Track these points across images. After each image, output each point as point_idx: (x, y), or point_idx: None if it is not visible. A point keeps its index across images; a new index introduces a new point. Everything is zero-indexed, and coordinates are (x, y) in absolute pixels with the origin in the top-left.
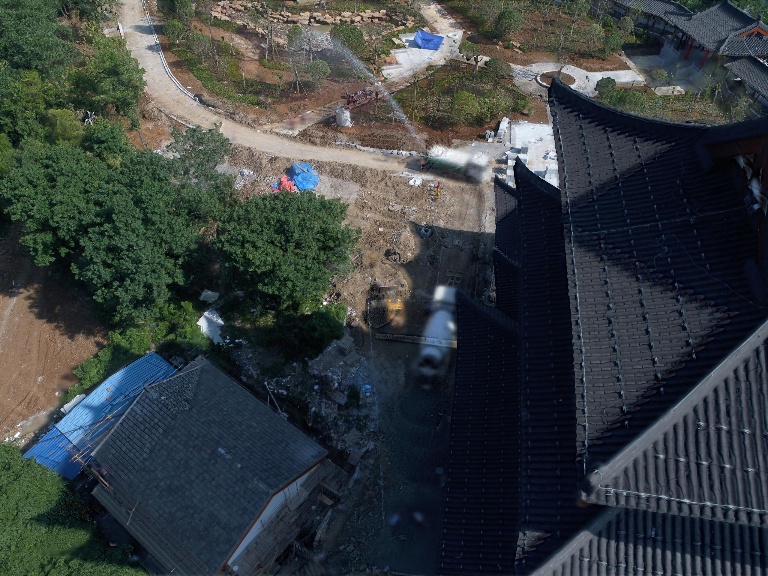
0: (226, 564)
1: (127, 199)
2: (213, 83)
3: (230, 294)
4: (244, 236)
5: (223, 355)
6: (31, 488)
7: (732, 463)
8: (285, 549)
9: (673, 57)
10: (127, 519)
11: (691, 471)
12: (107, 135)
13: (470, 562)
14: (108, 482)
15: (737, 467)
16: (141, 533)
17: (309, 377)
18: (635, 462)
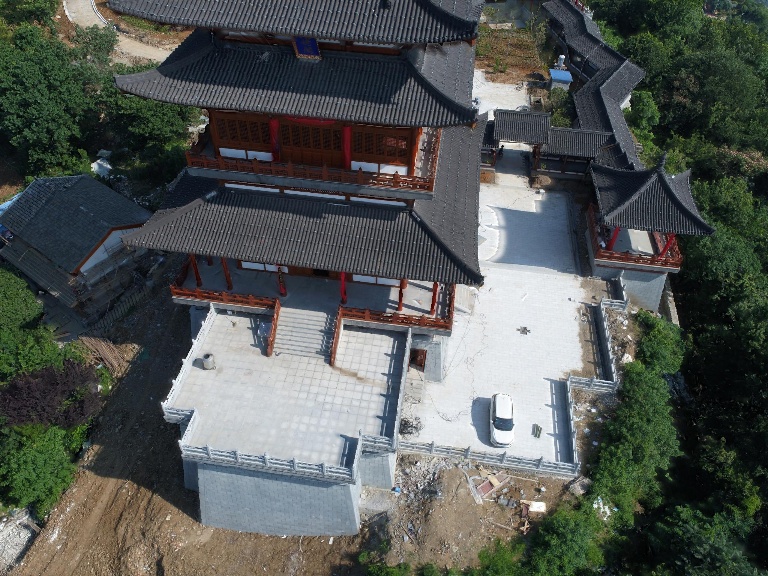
0: (79, 270)
1: (35, 68)
2: (130, 16)
3: (119, 150)
4: (117, 89)
5: (106, 183)
6: None
7: (179, 7)
8: (129, 282)
9: (512, 2)
10: (21, 264)
11: (161, 8)
12: (27, 33)
13: (184, 192)
14: (8, 241)
15: (181, 7)
16: (30, 271)
17: (165, 193)
18: (137, 2)
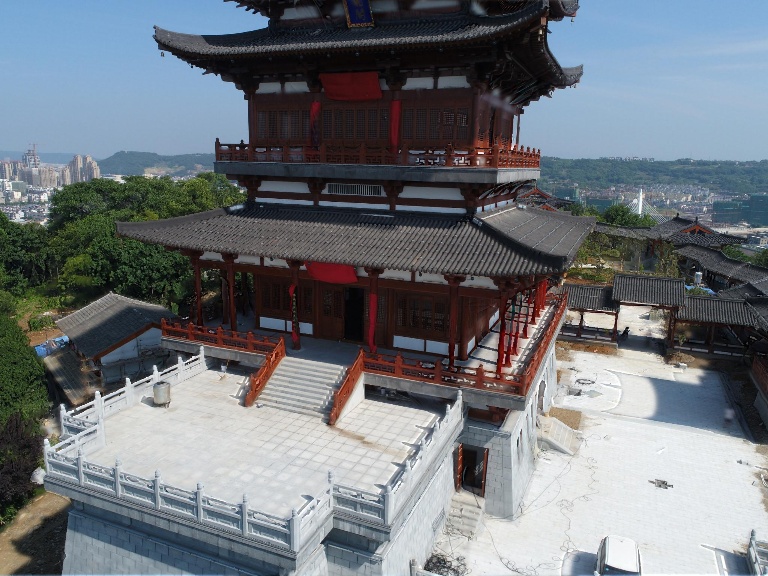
0: (99, 359)
1: None
2: None
3: None
4: None
5: None
6: (7, 320)
7: None
8: None
9: None
10: (55, 367)
11: None
12: None
13: None
14: None
15: None
16: (59, 372)
17: None
18: None
